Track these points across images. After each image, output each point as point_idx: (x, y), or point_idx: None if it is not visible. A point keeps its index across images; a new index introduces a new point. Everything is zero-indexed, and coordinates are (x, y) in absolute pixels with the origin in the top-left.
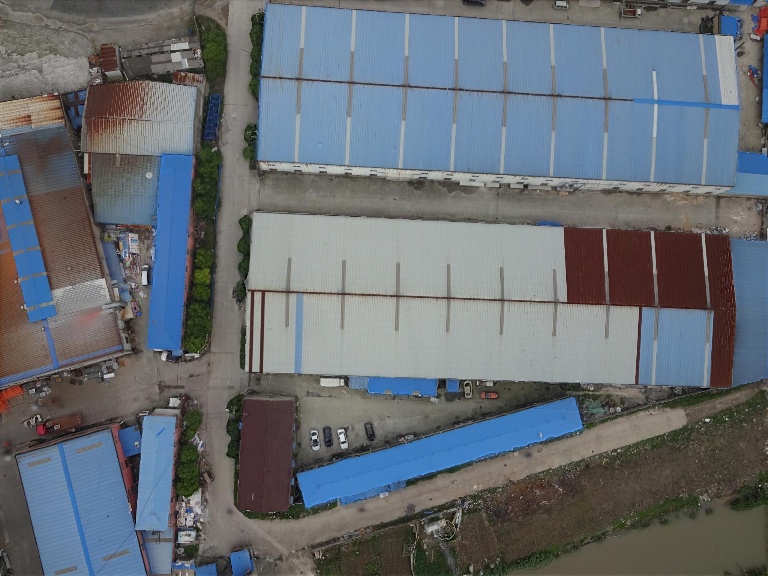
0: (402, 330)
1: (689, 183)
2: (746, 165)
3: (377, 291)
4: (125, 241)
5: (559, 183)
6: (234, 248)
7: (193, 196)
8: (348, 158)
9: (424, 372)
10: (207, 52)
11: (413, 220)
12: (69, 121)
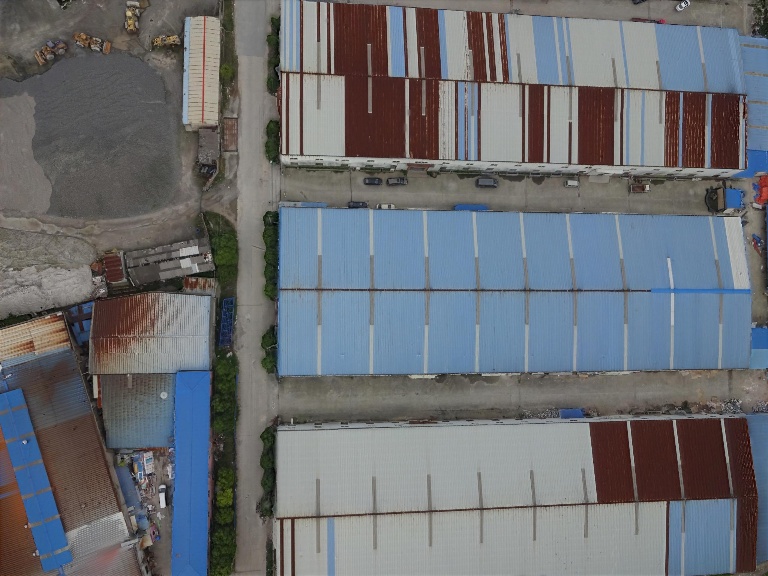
0: (436, 545)
1: (706, 368)
2: (757, 341)
3: (409, 508)
4: (140, 462)
5: None
6: (255, 458)
7: (212, 415)
8: (372, 367)
9: None
10: (219, 259)
11: (441, 427)
12: (74, 340)
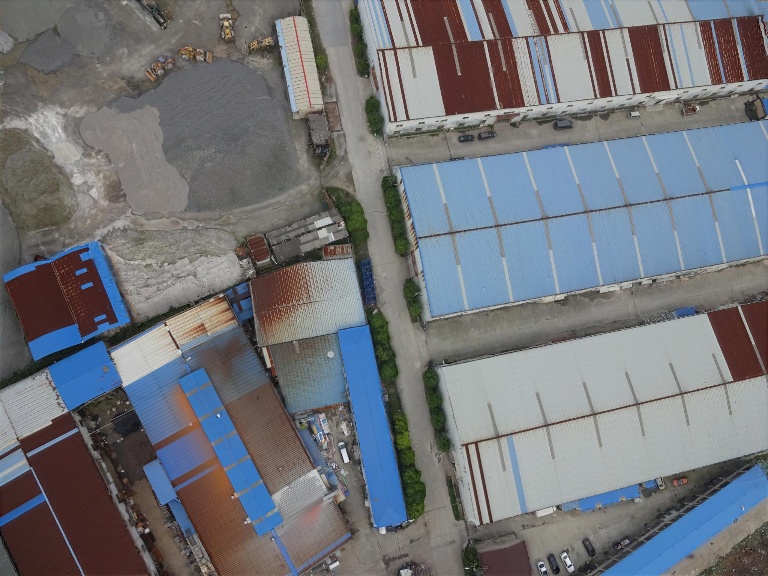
0: (605, 445)
1: None
2: None
3: (575, 414)
4: (316, 424)
5: (684, 273)
6: (418, 403)
7: (378, 365)
8: (511, 295)
9: (633, 479)
10: (353, 223)
11: (583, 339)
12: (238, 319)
